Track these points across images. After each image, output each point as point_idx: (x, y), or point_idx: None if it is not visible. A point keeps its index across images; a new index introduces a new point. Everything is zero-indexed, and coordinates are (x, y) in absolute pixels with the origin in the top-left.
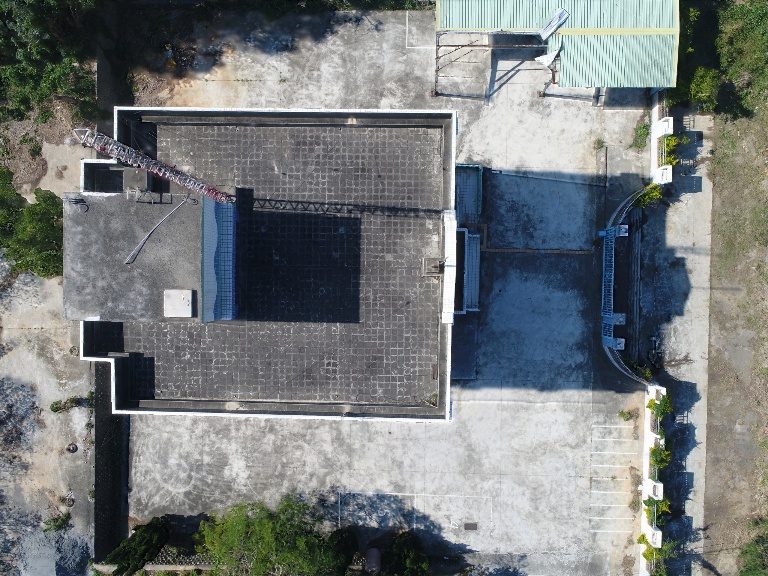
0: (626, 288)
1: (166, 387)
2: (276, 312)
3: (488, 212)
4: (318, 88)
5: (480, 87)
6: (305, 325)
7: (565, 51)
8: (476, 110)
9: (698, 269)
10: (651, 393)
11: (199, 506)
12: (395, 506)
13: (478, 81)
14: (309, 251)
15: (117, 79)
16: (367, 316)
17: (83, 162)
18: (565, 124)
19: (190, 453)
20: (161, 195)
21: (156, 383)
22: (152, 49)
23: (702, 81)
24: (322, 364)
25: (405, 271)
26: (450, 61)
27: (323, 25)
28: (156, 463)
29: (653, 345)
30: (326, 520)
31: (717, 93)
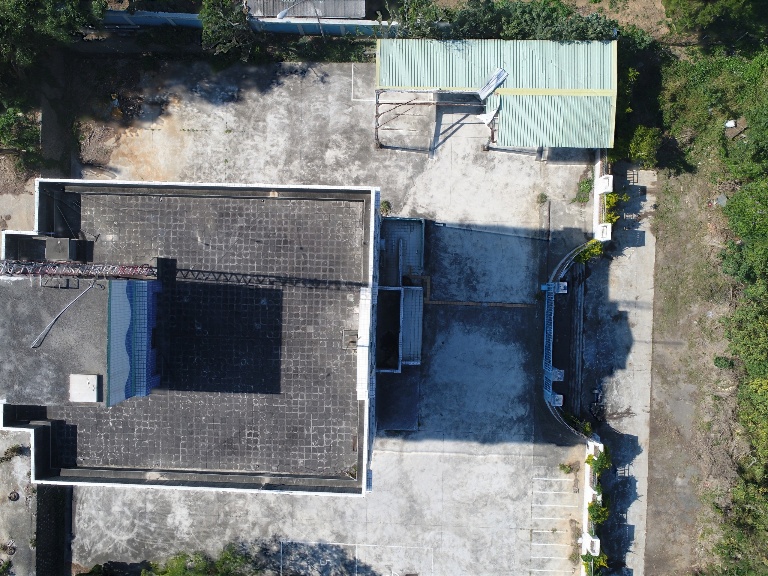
0: (568, 342)
1: (88, 455)
2: (198, 382)
3: (431, 264)
4: (264, 139)
5: (425, 140)
6: (227, 395)
7: (503, 111)
8: (420, 163)
9: (641, 323)
10: (590, 448)
11: (142, 554)
12: (337, 556)
13: (423, 134)
14: (231, 322)
15: (64, 127)
16: (288, 387)
17: (4, 233)
18: (509, 178)
19: (133, 501)
20: (68, 280)
21: (78, 451)
22: (98, 99)
23: (642, 140)
24: (243, 434)
25: (326, 343)
26: (395, 114)
27: (269, 76)
28: (99, 510)
29: (595, 398)
30: (268, 569)
31: (655, 154)
